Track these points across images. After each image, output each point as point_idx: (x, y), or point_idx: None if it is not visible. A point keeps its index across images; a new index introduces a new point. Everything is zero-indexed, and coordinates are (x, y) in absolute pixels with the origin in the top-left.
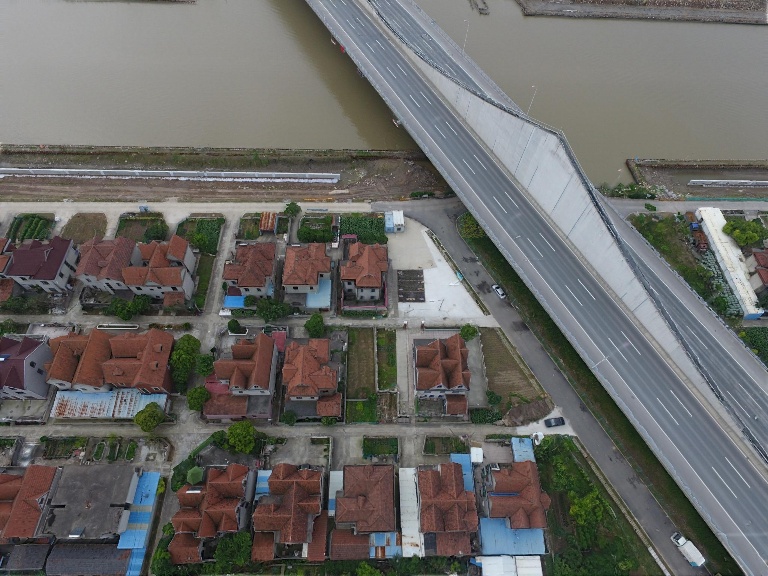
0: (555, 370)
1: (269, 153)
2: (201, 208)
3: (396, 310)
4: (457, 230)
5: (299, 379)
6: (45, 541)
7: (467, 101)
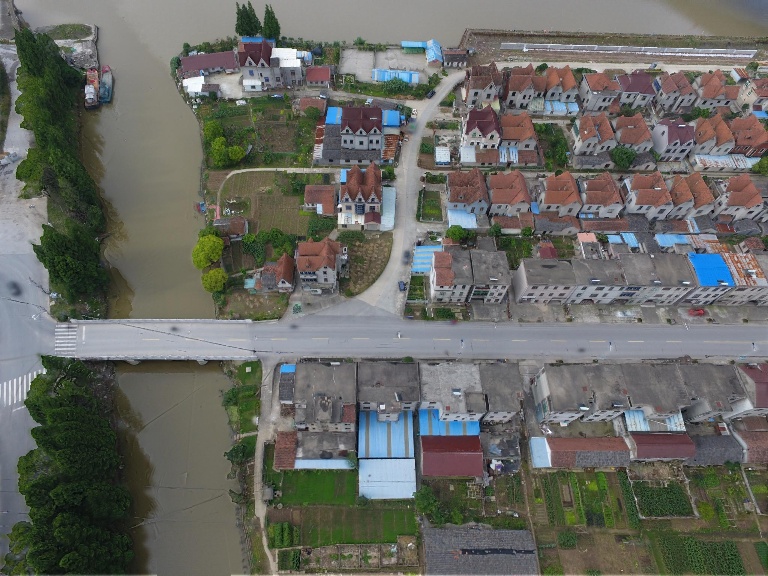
0: None
1: (698, 38)
2: (684, 68)
3: None
4: None
5: None
6: None
7: None
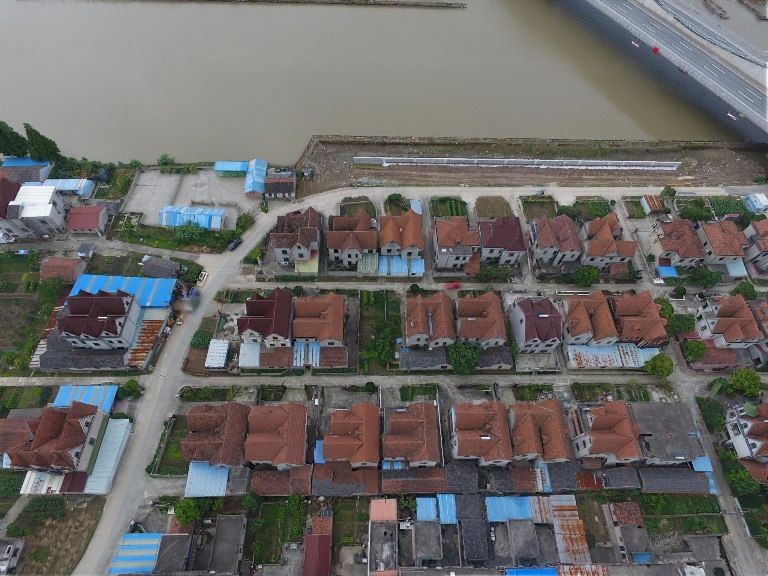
0: None
1: (609, 144)
2: (582, 192)
3: None
4: None
5: None
6: (630, 466)
7: None
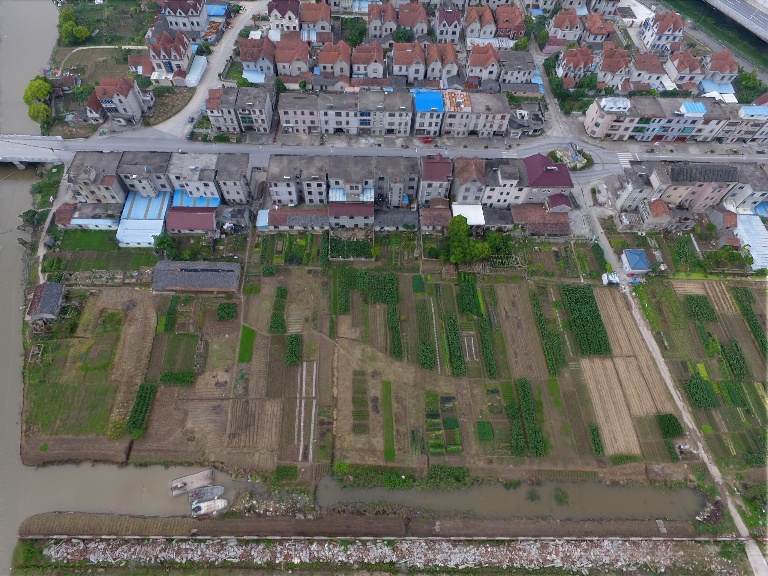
0: (717, 44)
1: None
2: None
3: (622, 21)
4: None
5: (600, 23)
6: None
7: None
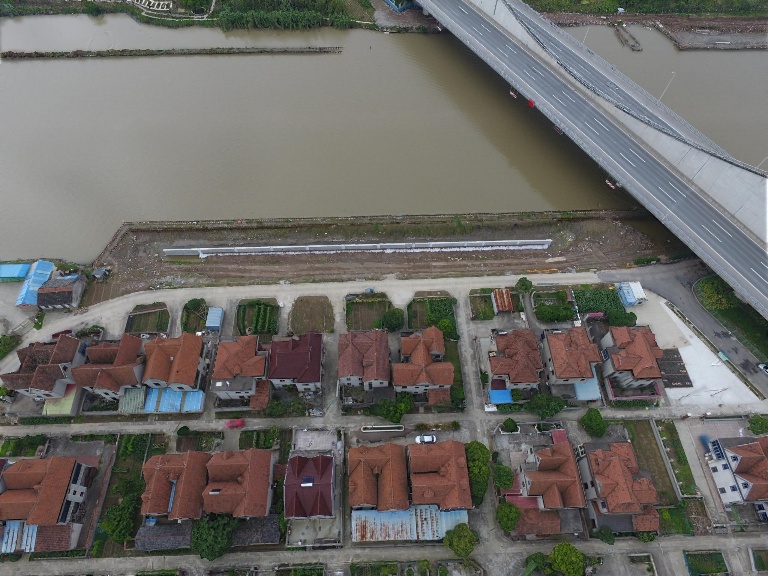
0: None
1: (471, 219)
2: (424, 286)
3: (666, 397)
4: (697, 300)
5: (626, 496)
6: None
7: (701, 162)
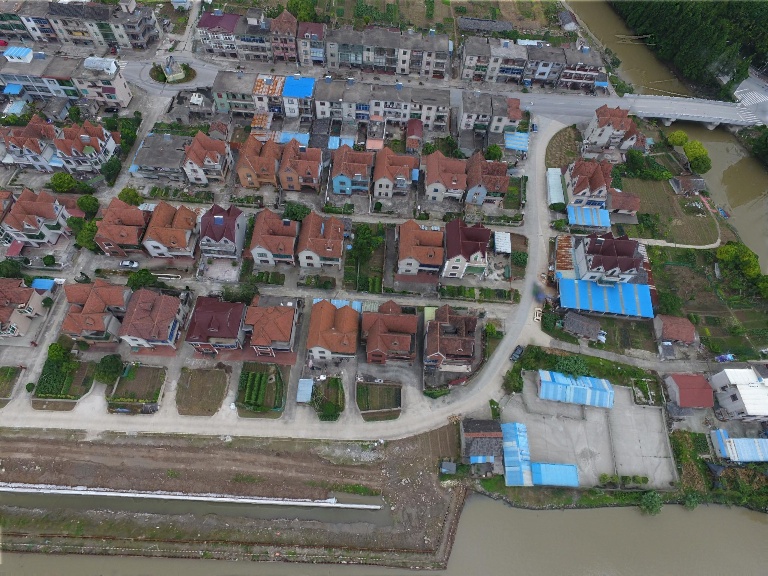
0: None
1: None
2: (58, 418)
3: None
4: None
5: None
6: None
7: None
